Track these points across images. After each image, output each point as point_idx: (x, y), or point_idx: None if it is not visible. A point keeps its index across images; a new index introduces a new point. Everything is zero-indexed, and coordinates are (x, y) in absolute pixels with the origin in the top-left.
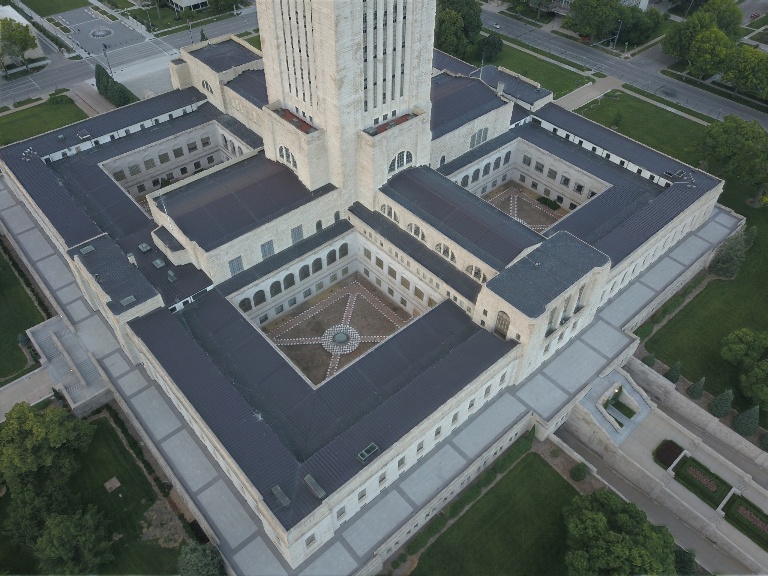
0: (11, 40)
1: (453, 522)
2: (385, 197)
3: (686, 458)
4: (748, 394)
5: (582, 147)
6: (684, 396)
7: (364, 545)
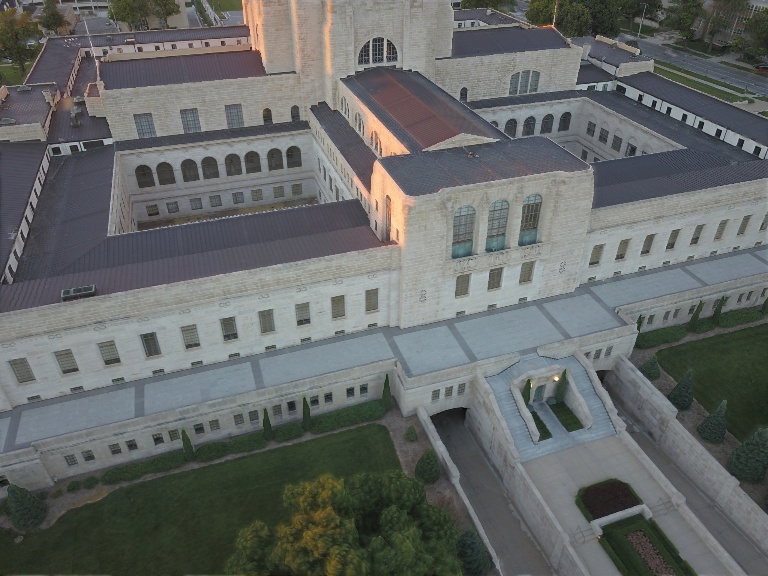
0: (157, 1)
1: (196, 467)
2: (342, 85)
3: (641, 519)
4: None
5: (670, 116)
6: (688, 431)
7: (34, 432)
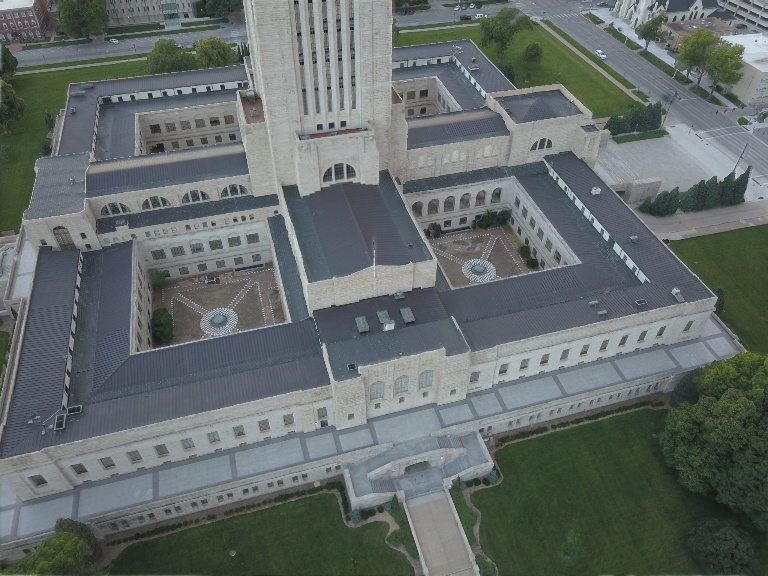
0: None
1: None
2: None
3: None
4: None
5: None
6: None
7: None
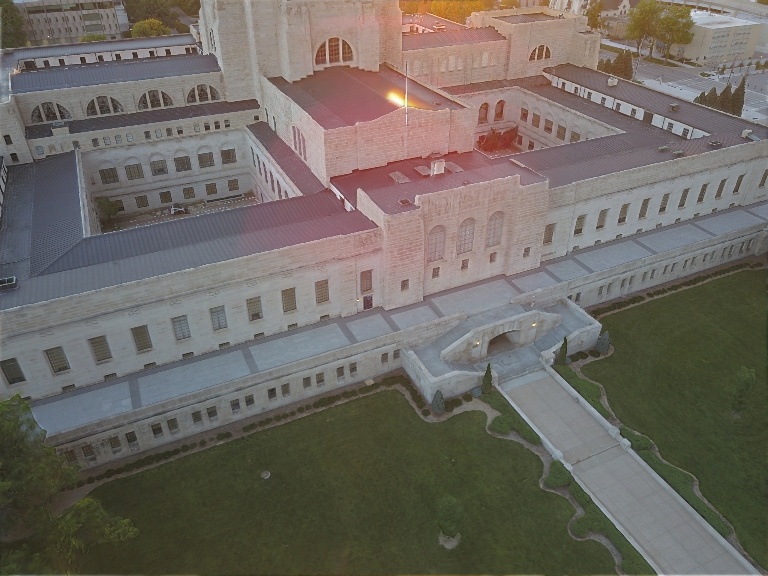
0: None
1: None
2: None
3: None
4: None
5: None
6: None
7: None
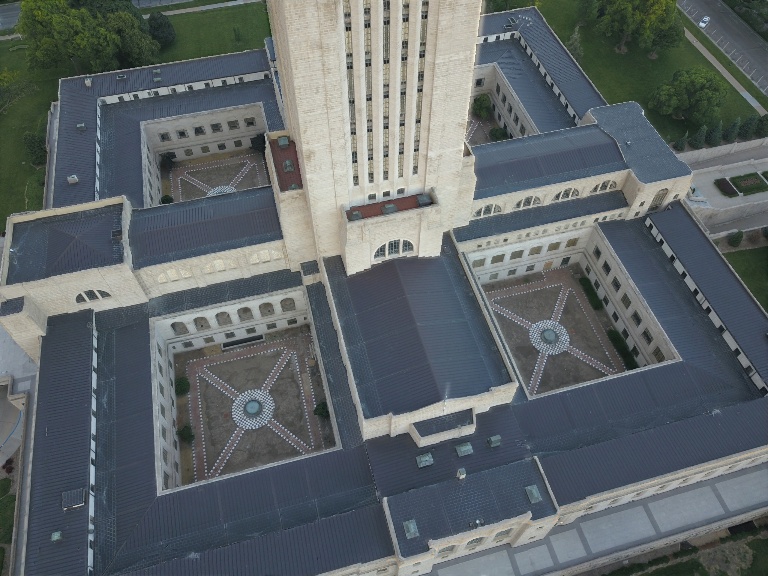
0: None
1: None
2: (483, 201)
3: (730, 181)
4: (703, 121)
5: None
6: (681, 153)
7: None
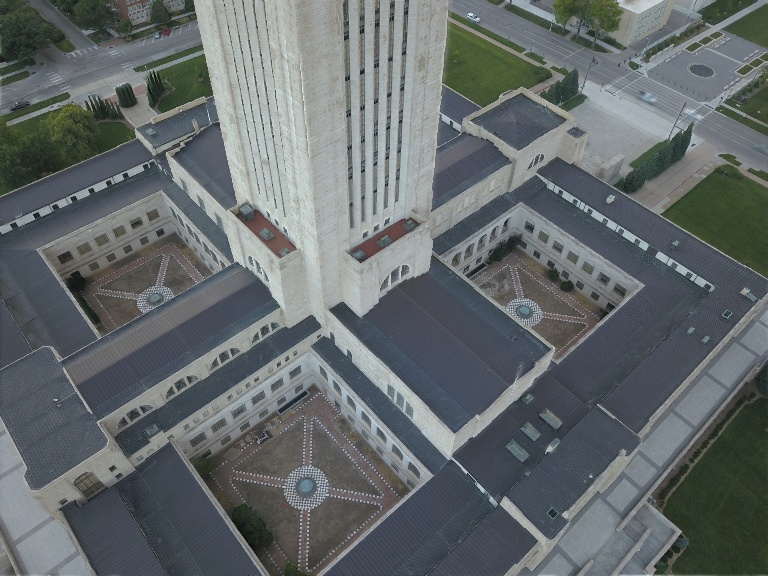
0: None
1: None
2: None
3: None
4: None
5: None
6: None
7: None
